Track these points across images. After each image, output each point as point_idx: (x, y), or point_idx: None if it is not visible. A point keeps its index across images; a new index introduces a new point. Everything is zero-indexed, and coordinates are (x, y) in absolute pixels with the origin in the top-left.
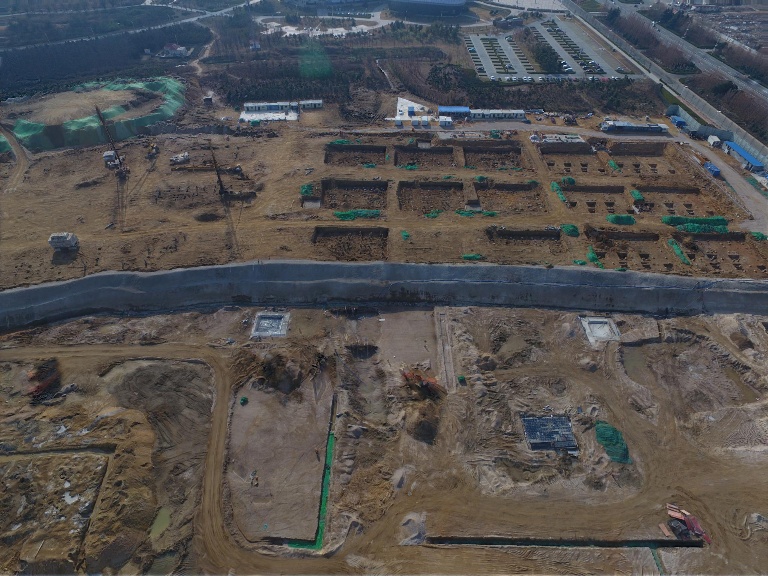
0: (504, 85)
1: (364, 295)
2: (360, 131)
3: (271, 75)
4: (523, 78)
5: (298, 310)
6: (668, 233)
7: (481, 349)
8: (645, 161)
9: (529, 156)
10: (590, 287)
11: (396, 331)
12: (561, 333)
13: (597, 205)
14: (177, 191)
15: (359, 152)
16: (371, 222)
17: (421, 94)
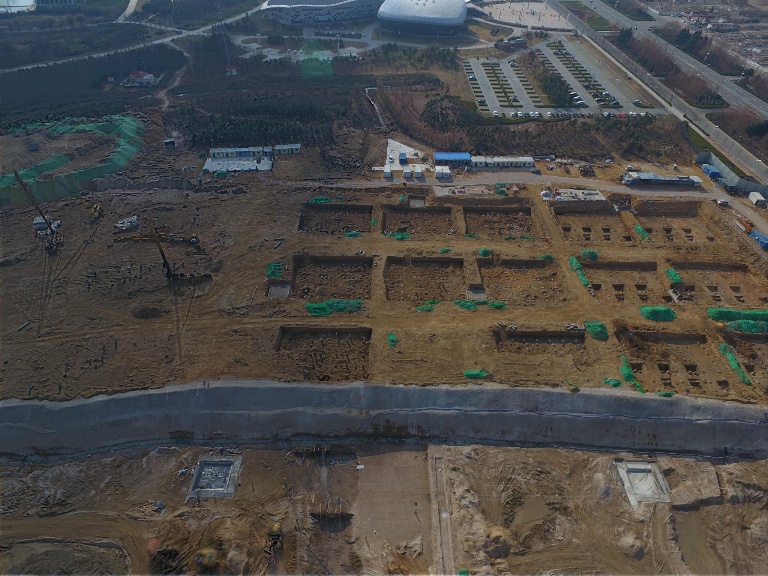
0: (509, 122)
1: (338, 430)
2: (343, 185)
3: (245, 110)
4: (530, 113)
5: (253, 452)
6: (718, 334)
7: (489, 519)
8: (677, 224)
9: (541, 219)
10: (627, 419)
11: (378, 486)
12: (593, 490)
13: (626, 289)
14: (116, 272)
15: (341, 213)
16: (350, 319)
17: (415, 134)
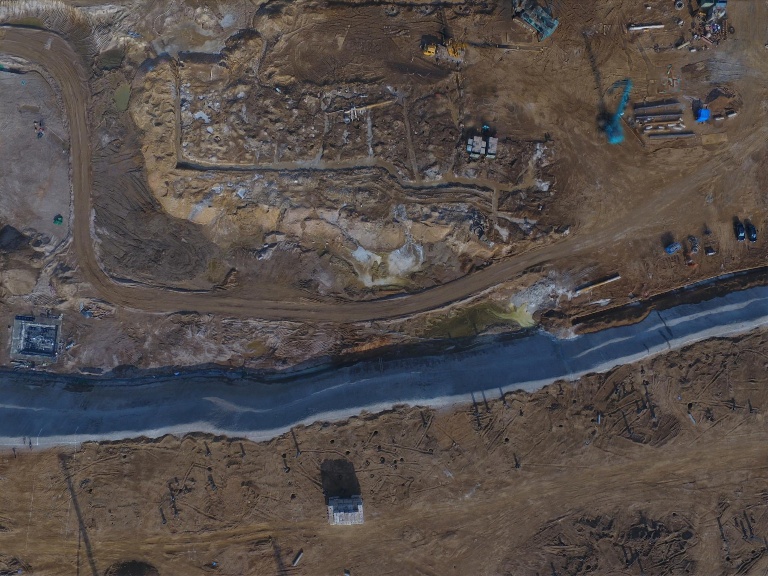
0: None
1: None
2: None
3: None
4: None
5: None
6: None
7: None
8: None
9: None
10: None
11: None
12: None
13: None
14: None
15: None
16: None
17: None
